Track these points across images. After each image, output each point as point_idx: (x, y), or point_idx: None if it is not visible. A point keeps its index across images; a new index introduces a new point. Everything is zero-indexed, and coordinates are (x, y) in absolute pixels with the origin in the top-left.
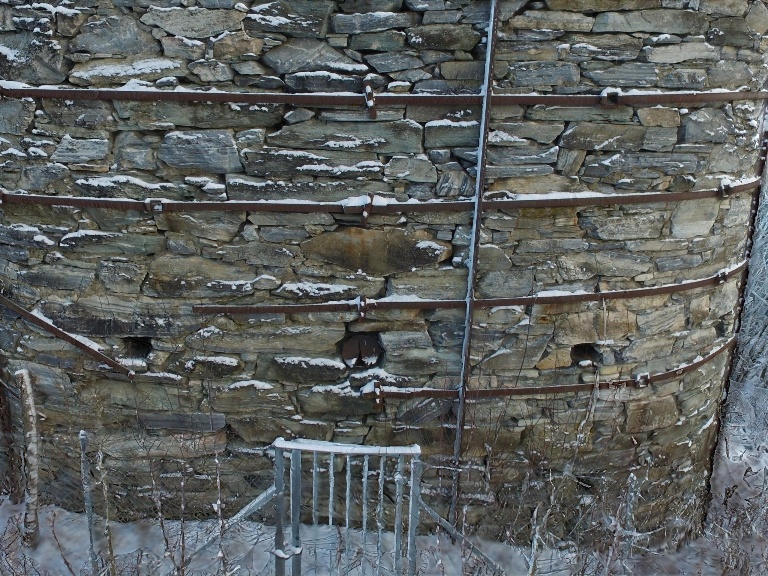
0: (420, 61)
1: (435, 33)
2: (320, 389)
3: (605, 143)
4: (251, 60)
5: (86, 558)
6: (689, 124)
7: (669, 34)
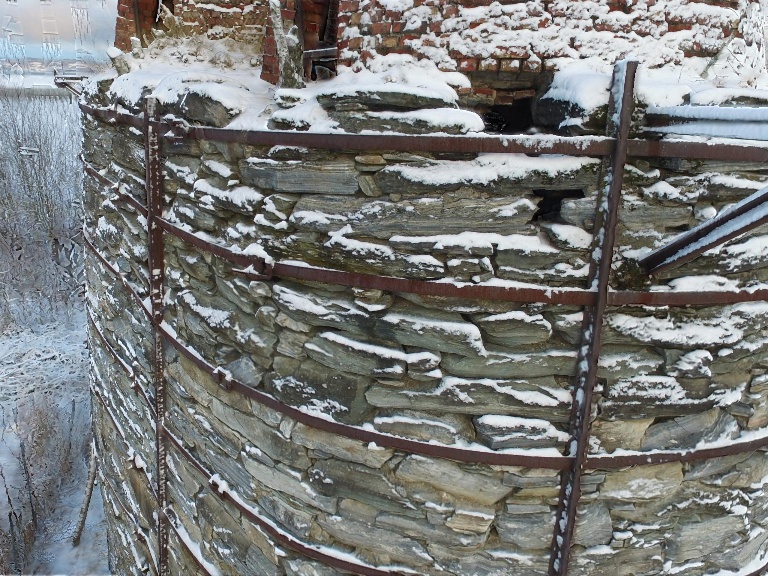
0: (149, 367)
1: (149, 350)
2: (134, 571)
3: (221, 529)
4: (110, 320)
5: (70, 574)
6: (289, 571)
7: (262, 450)
